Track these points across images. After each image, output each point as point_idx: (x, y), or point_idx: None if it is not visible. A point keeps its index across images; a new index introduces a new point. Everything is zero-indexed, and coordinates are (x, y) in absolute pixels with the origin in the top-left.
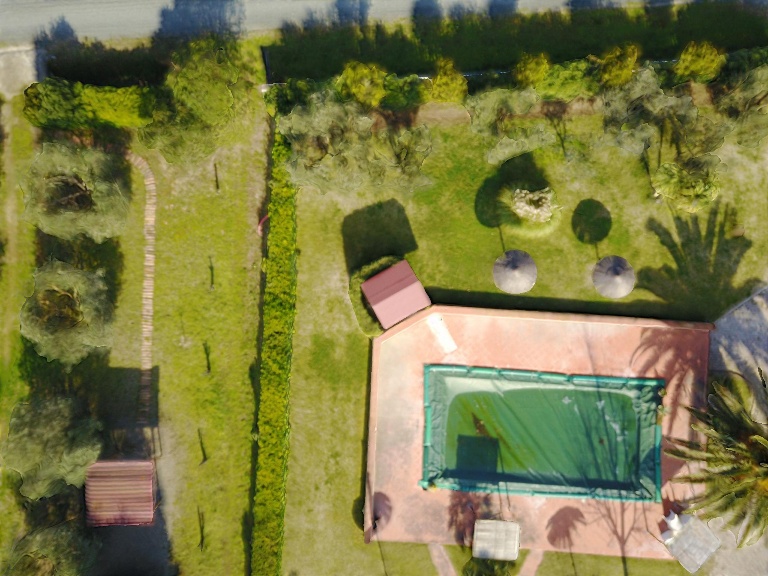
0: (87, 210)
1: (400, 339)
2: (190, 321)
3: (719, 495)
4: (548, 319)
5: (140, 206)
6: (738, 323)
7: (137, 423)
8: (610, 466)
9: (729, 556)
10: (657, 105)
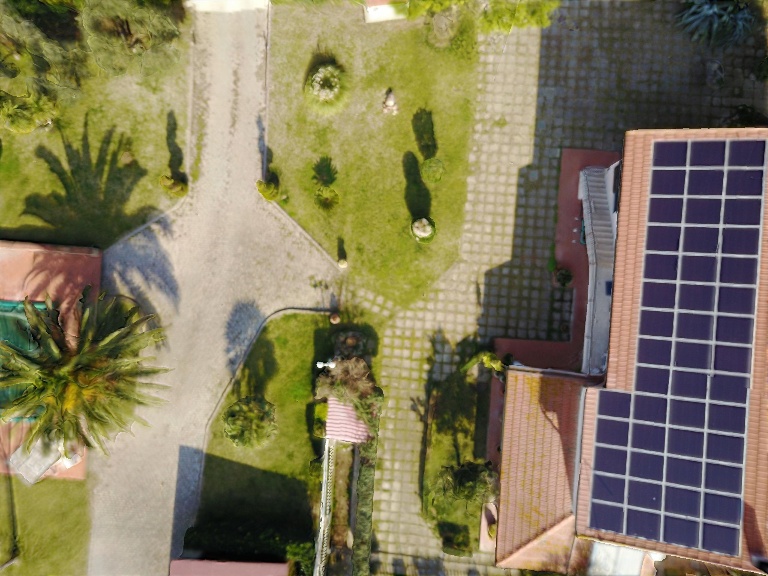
0: None
1: None
2: None
3: None
4: None
5: None
6: (134, 249)
7: None
8: (3, 387)
9: (114, 474)
10: (10, 32)
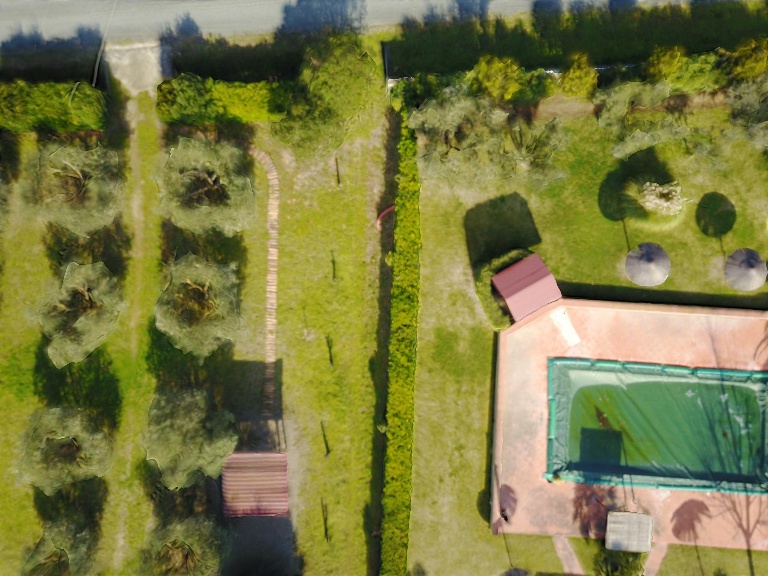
0: (217, 204)
1: (524, 332)
2: (313, 314)
3: None
4: (674, 312)
5: (263, 200)
6: None
7: (262, 415)
8: (734, 459)
9: None
10: None
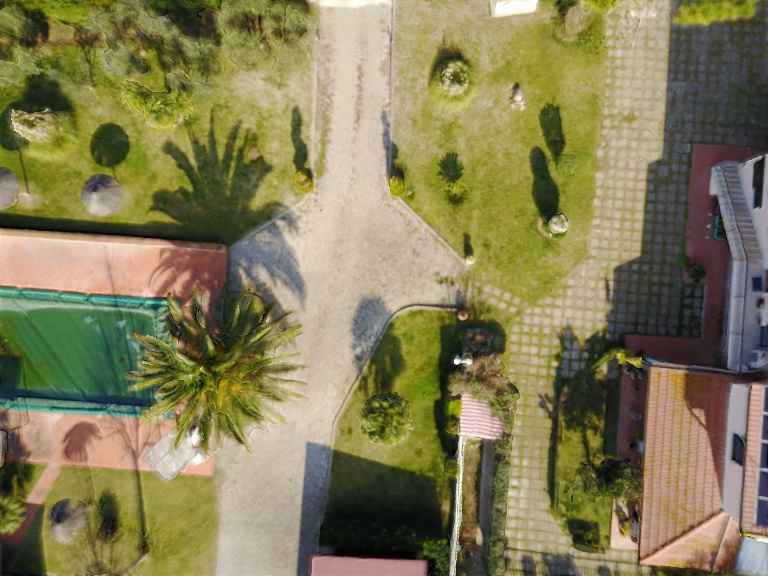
0: None
1: None
2: None
3: (166, 401)
4: (57, 238)
5: None
6: (259, 246)
7: None
8: (130, 383)
9: (242, 470)
10: (144, 27)
